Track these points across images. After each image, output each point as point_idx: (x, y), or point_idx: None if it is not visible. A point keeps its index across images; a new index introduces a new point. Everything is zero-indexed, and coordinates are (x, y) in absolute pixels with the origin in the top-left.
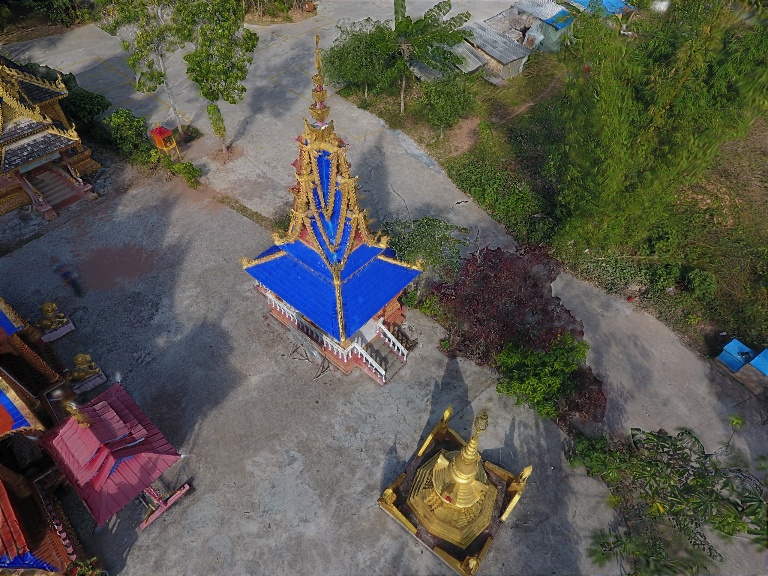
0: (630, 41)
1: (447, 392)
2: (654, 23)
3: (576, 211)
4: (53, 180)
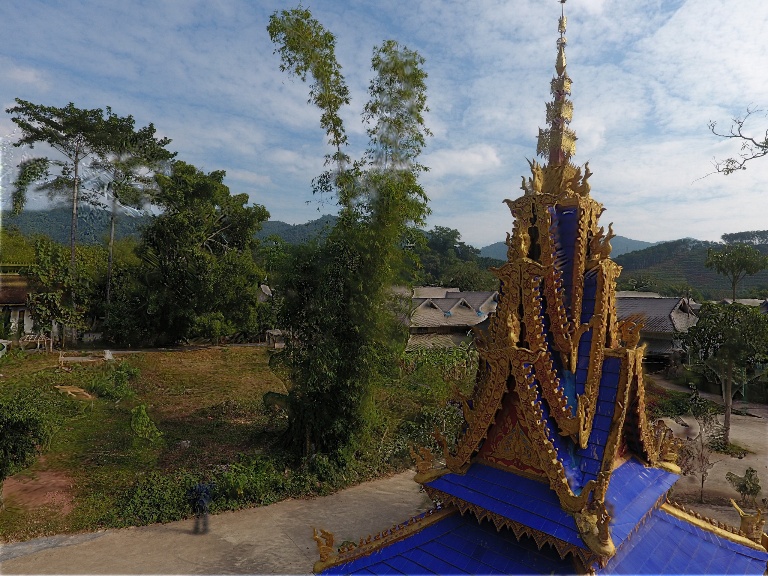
0: (301, 249)
1: None
2: None
3: (357, 408)
4: None
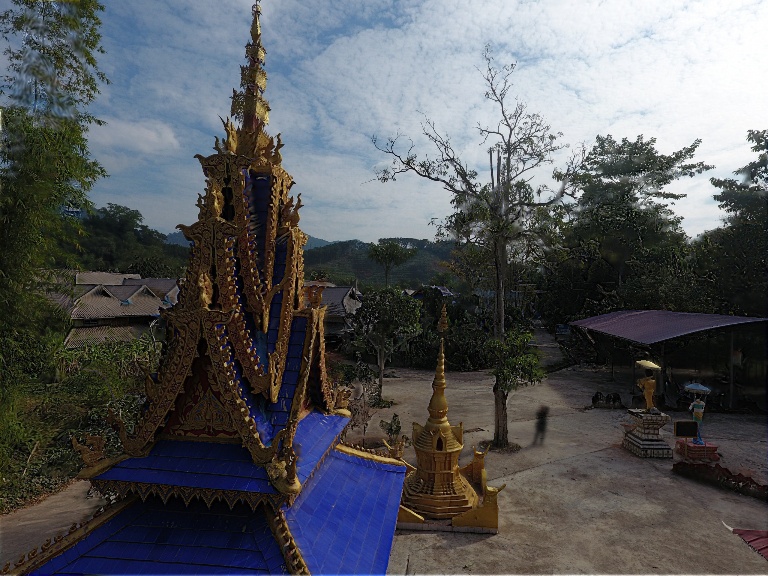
0: None
1: None
2: None
3: None
4: None
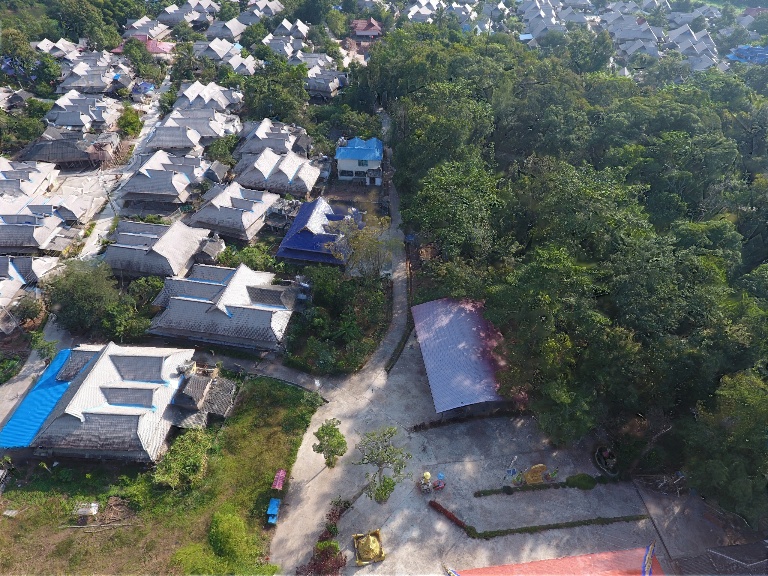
0: None
1: (347, 575)
2: (241, 572)
3: None
4: None
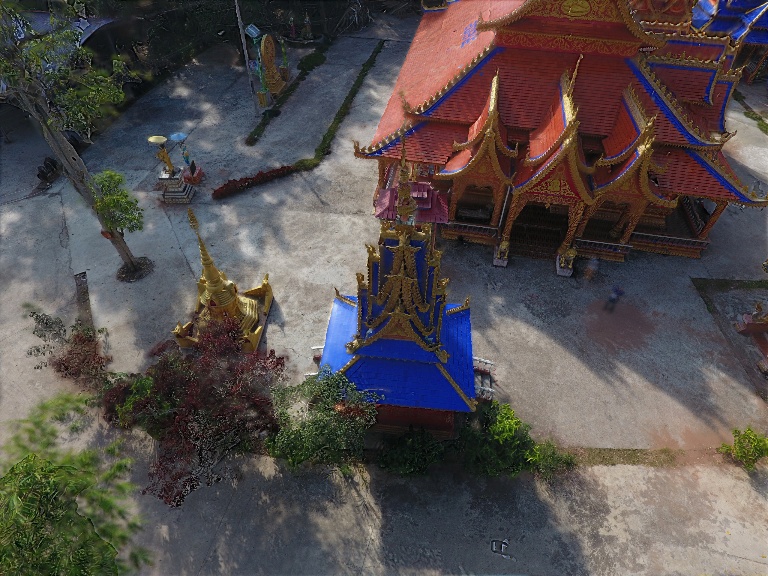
0: None
1: None
2: None
3: None
4: None
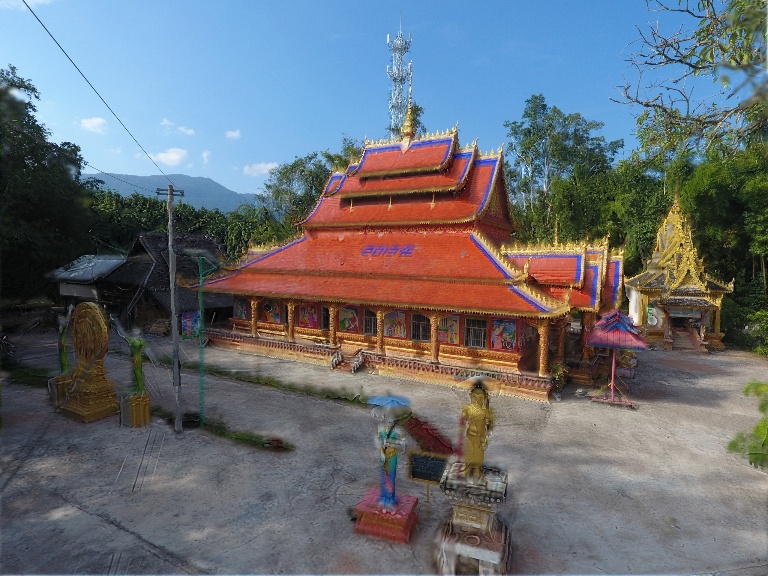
0: None
1: None
2: None
3: None
4: (685, 337)
